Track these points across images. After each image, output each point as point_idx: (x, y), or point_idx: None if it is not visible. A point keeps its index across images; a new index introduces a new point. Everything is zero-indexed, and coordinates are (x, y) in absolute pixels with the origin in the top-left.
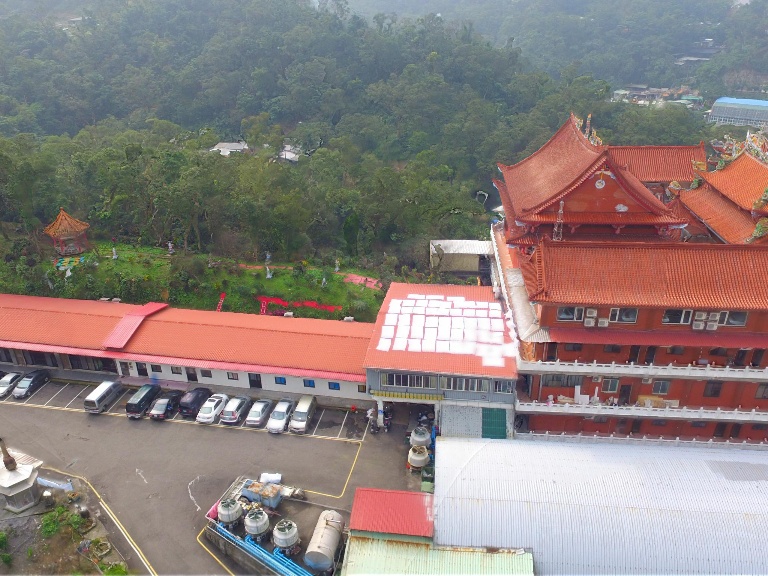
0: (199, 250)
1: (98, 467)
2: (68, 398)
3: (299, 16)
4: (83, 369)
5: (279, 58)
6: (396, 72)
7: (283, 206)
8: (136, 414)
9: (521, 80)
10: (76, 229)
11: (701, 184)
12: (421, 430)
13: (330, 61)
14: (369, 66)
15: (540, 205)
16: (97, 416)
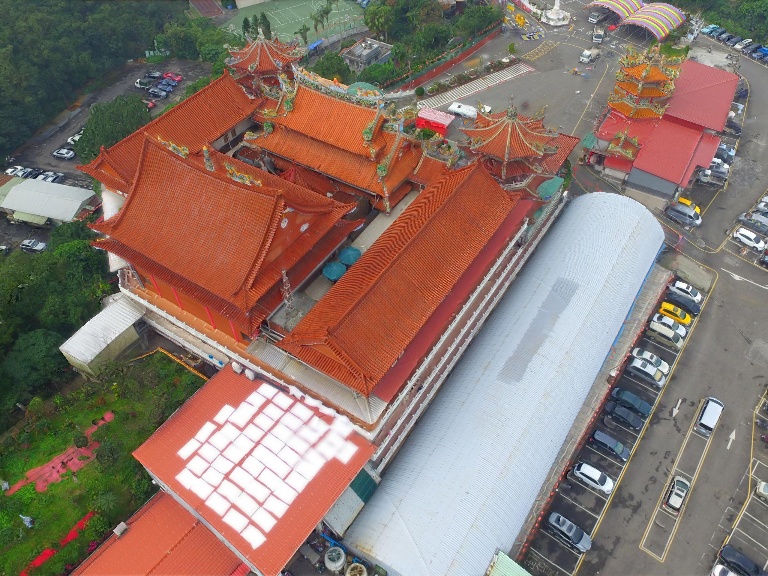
0: None
1: None
2: None
3: None
4: None
5: None
6: None
7: None
8: None
9: None
10: None
11: (274, 126)
12: (335, 555)
13: None
14: None
15: (247, 278)
16: None
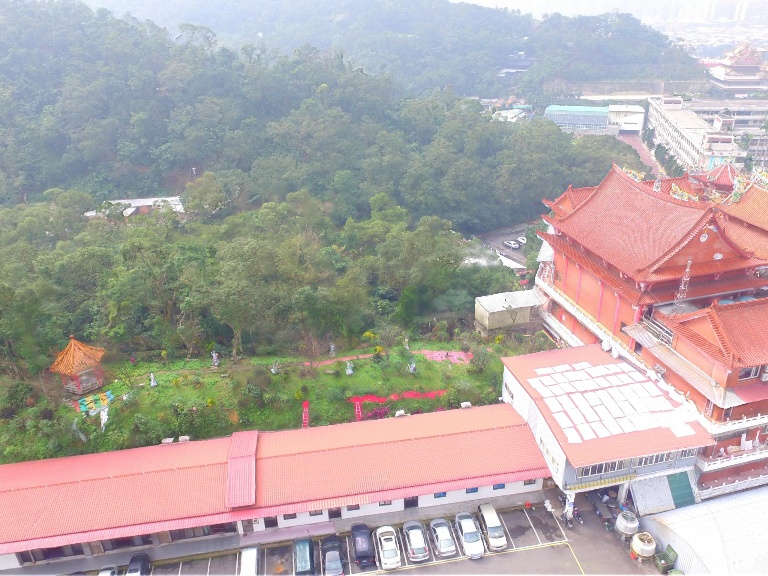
0: (244, 354)
1: None
2: None
3: (160, 50)
4: (187, 538)
5: (153, 99)
6: (286, 107)
7: (336, 289)
8: None
9: (416, 108)
10: (96, 359)
11: None
12: (630, 515)
13: (224, 101)
14: (254, 102)
15: (653, 264)
16: None
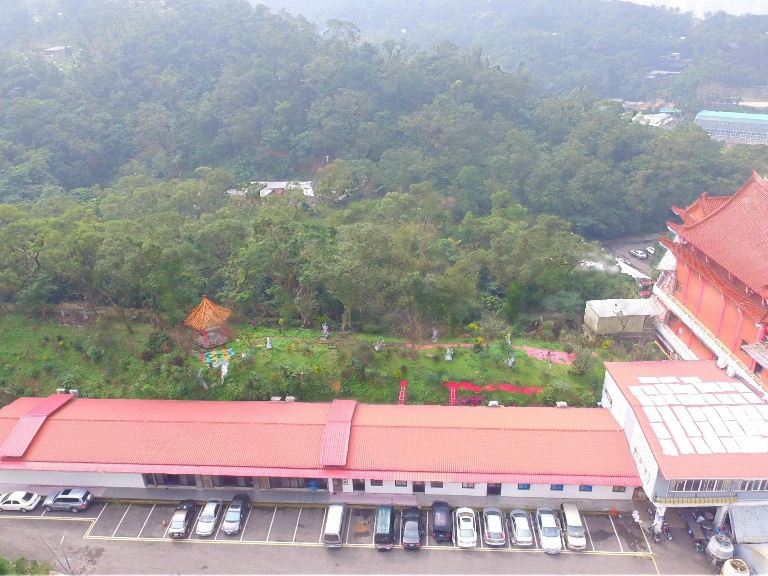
0: (352, 330)
1: None
2: (289, 529)
3: (308, 44)
4: (283, 487)
5: (297, 90)
6: (419, 101)
7: (444, 277)
8: (387, 545)
9: (550, 107)
10: (223, 318)
11: None
12: (724, 539)
13: (361, 94)
14: (390, 95)
15: None
16: (338, 550)
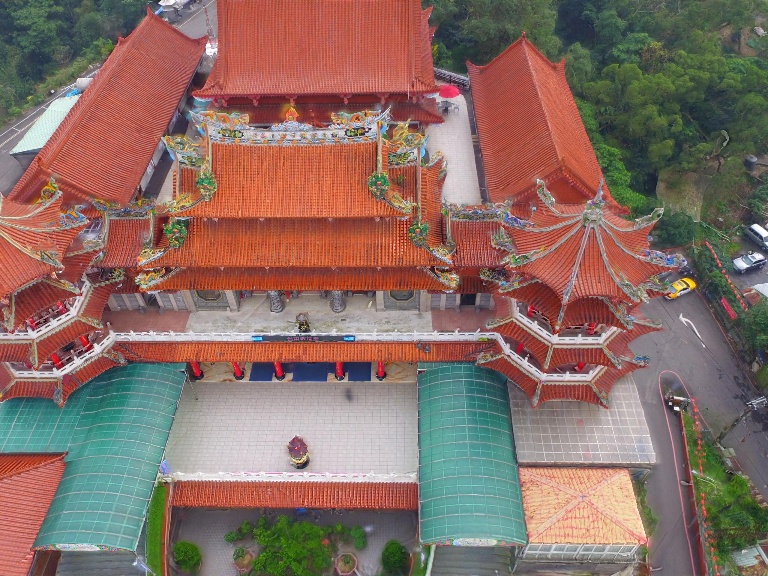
0: None
1: (187, 28)
2: None
3: None
4: None
5: None
6: None
7: None
8: None
9: None
10: None
11: None
12: None
13: None
14: None
15: None
16: None
